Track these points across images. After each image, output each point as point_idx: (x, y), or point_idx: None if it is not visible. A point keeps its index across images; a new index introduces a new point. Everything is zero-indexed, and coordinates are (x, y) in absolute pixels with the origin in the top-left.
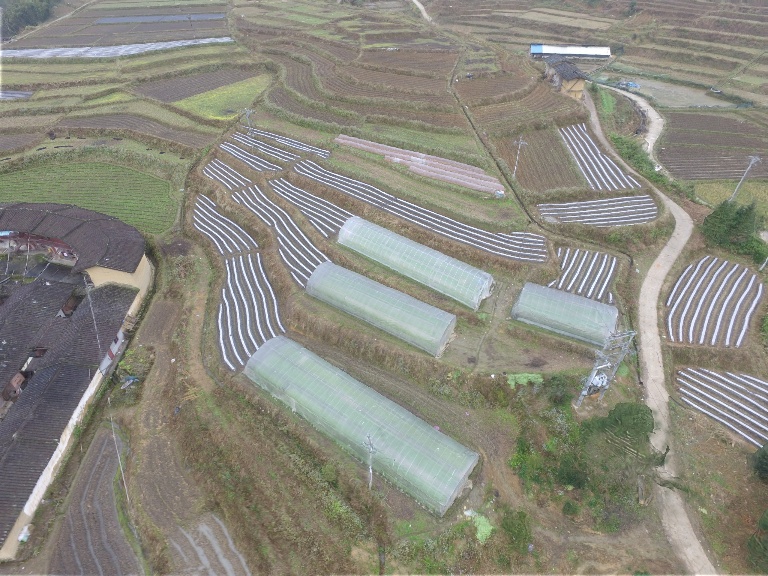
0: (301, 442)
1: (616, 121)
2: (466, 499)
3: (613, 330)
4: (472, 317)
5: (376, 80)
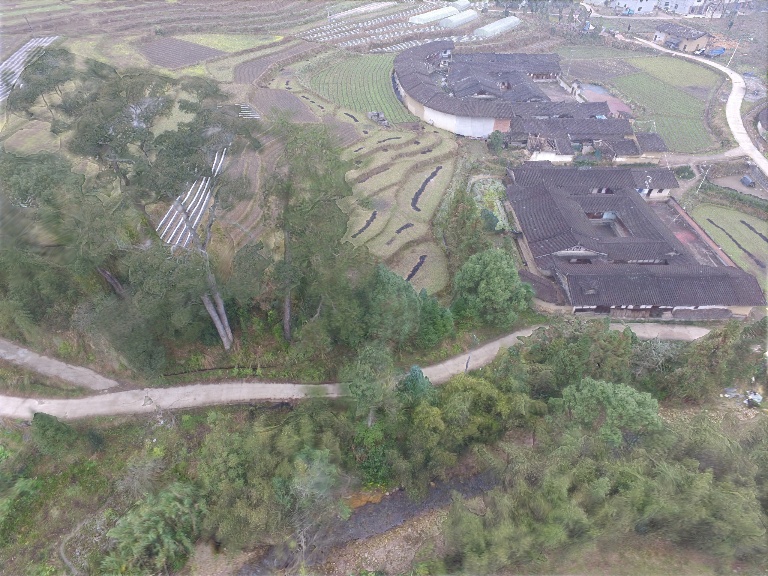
0: None
1: None
2: None
3: None
4: None
5: (255, 4)
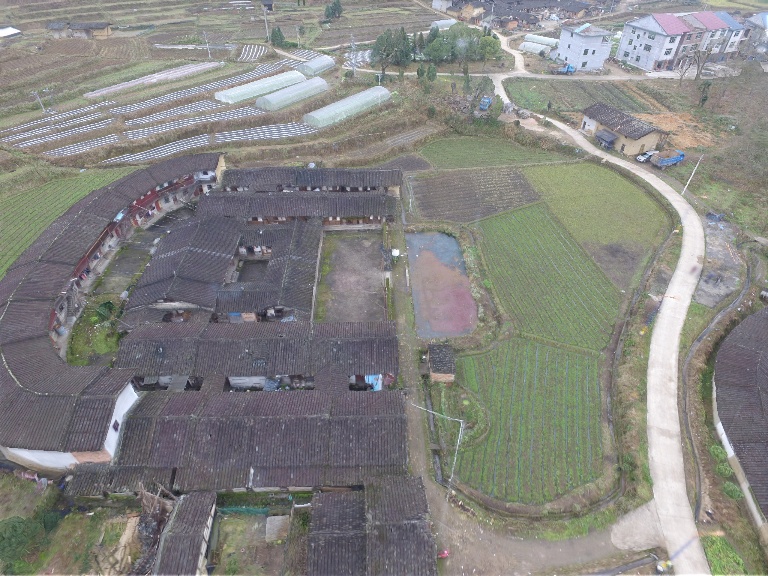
0: None
1: None
2: None
3: (331, 58)
4: None
5: None
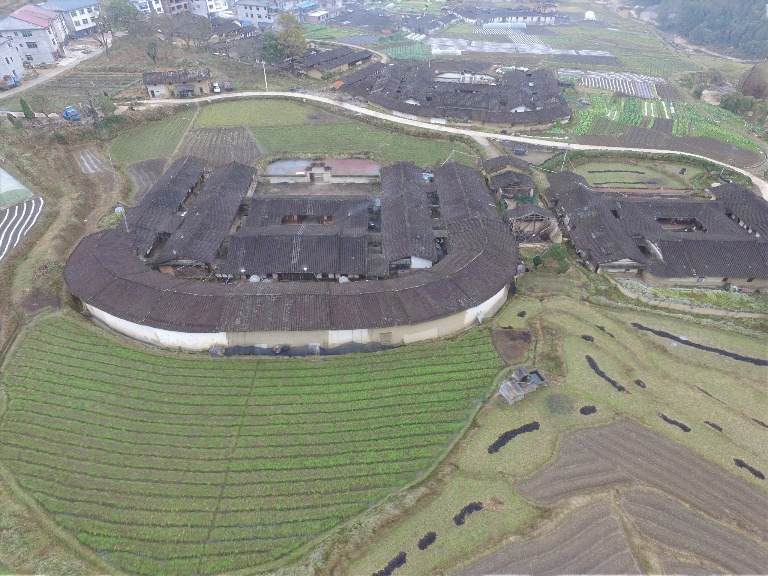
0: None
1: None
2: None
3: None
4: None
5: None
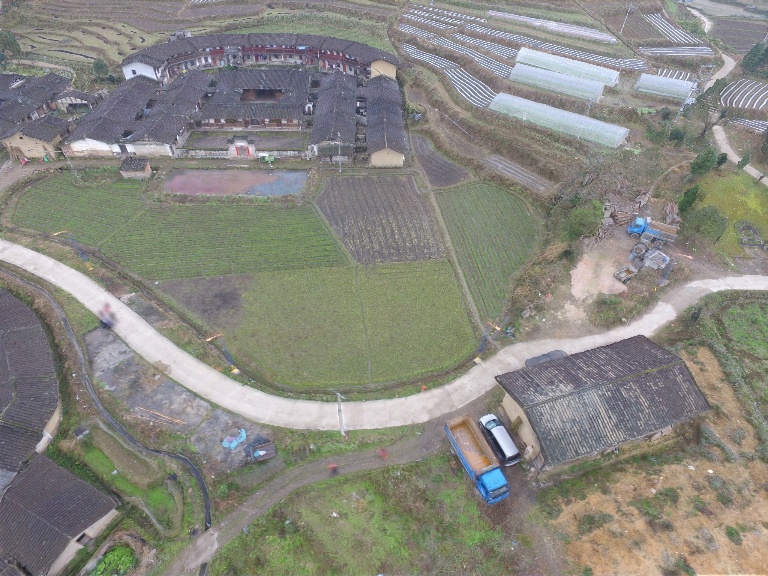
0: (533, 130)
1: (678, 18)
2: (625, 145)
3: None
4: (611, 89)
5: None
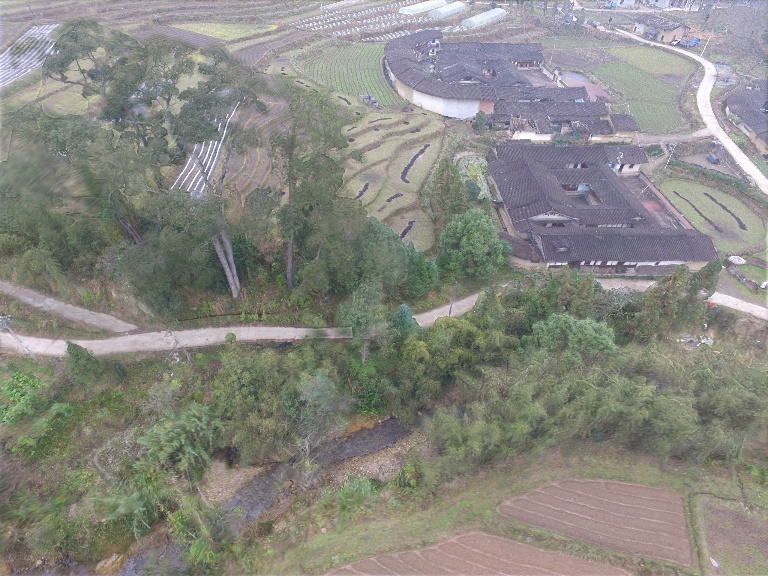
0: None
1: None
2: None
3: None
4: None
5: None
